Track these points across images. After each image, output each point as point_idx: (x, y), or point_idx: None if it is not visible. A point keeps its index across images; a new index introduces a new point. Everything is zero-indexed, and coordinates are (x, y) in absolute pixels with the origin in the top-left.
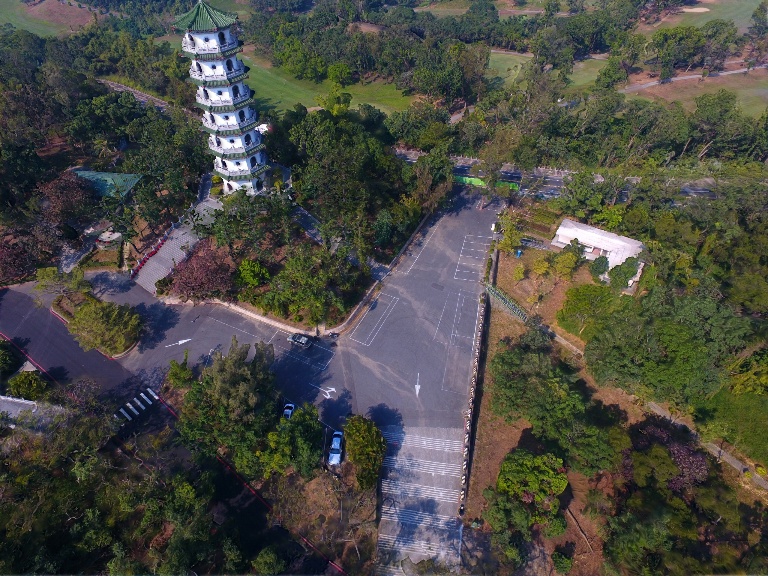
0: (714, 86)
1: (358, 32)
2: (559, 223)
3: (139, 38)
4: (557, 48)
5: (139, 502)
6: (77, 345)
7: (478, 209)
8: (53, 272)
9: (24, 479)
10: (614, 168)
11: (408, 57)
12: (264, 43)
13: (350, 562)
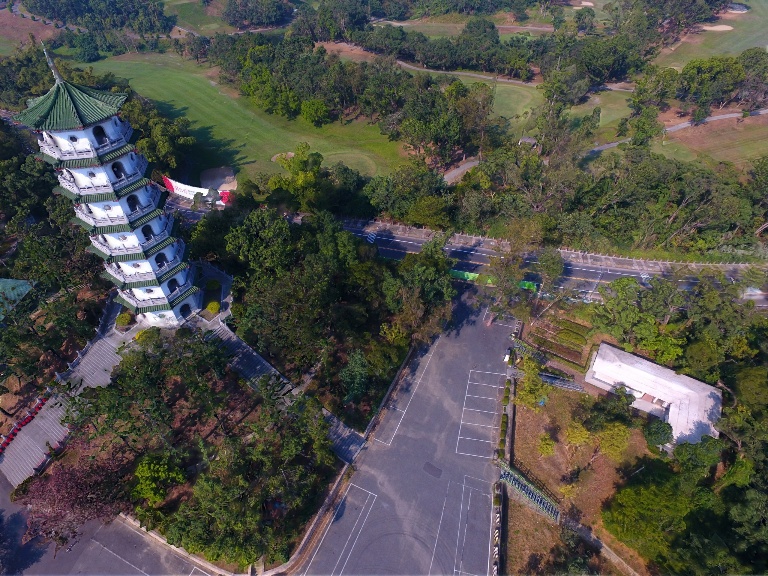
0: (756, 128)
1: (336, 63)
2: (593, 344)
3: (95, 57)
4: (577, 92)
5: None
6: None
7: (485, 324)
8: None
9: None
10: (652, 247)
11: (395, 96)
12: (230, 70)
13: None
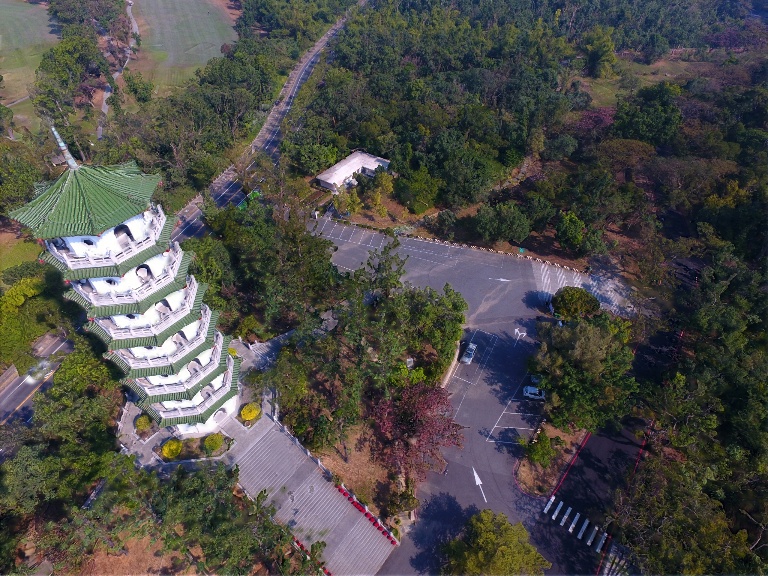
0: None
1: None
2: None
3: None
4: None
5: (706, 412)
6: None
7: None
8: None
9: (744, 534)
10: None
11: None
12: None
13: None
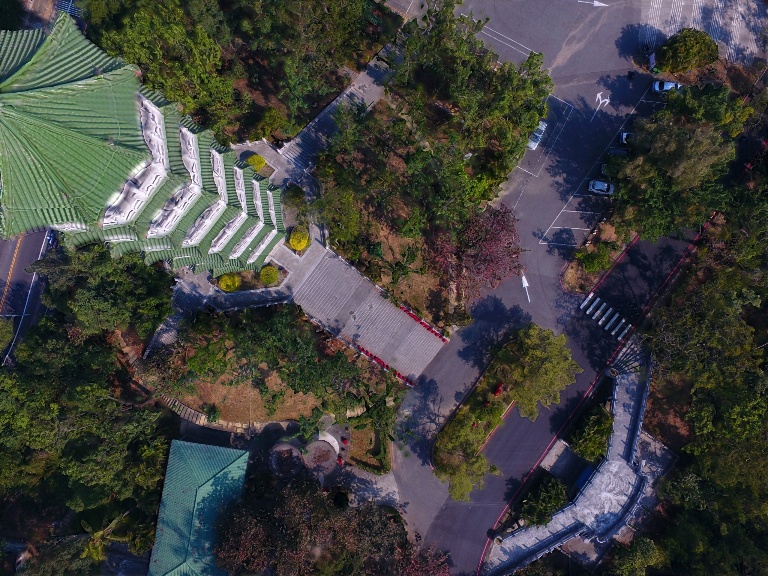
0: None
1: None
2: None
3: None
4: None
5: None
6: (519, 415)
7: None
8: (475, 463)
9: (760, 353)
10: None
11: None
12: None
13: (743, 87)
